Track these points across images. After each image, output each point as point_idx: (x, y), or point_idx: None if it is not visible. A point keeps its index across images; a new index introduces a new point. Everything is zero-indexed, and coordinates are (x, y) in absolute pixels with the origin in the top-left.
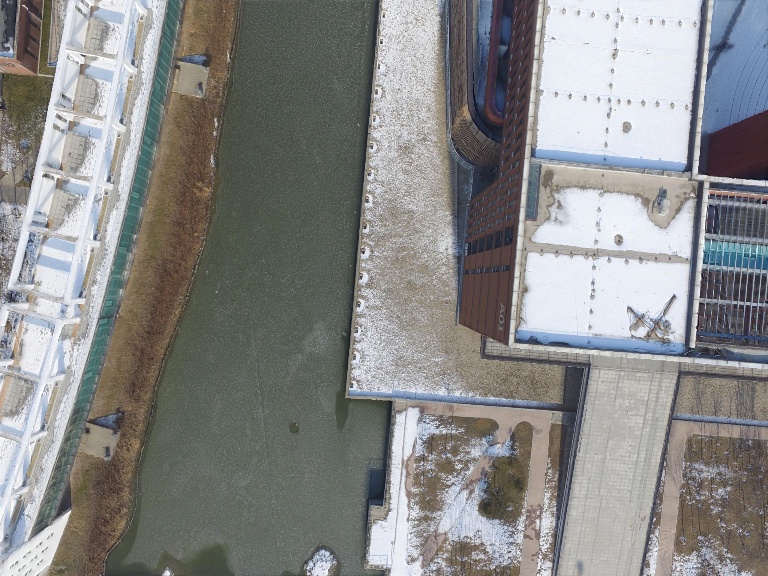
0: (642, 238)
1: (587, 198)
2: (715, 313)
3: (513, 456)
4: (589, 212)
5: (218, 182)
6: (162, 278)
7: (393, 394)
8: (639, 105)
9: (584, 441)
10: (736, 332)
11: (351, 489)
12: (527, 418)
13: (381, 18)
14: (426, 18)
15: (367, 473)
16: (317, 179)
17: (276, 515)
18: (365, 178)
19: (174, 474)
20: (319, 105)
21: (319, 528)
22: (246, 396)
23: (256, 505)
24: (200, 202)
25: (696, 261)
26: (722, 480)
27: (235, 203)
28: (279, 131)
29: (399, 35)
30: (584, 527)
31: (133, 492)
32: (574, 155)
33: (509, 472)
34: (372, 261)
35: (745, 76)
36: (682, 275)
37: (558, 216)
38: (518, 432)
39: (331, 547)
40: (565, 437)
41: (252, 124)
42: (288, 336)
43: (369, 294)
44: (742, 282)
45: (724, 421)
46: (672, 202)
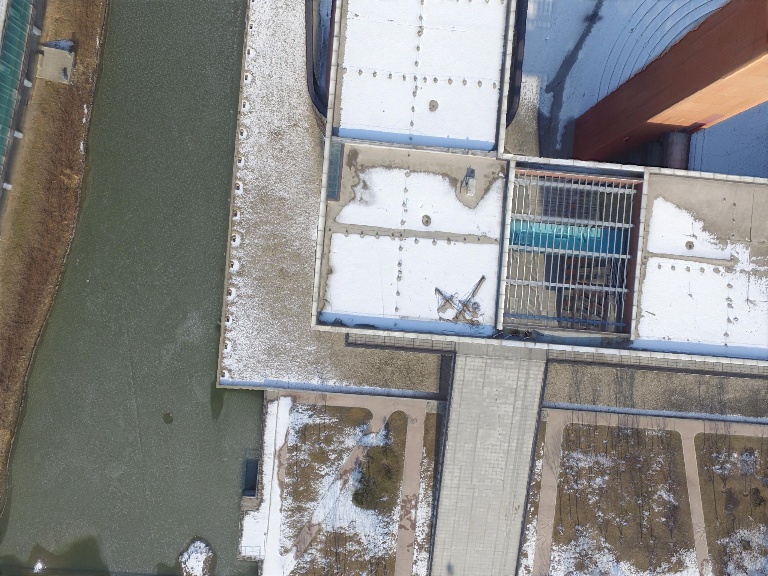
0: (450, 218)
1: (393, 178)
2: (526, 295)
3: (388, 446)
4: (395, 192)
5: (88, 169)
6: (29, 267)
7: (265, 383)
8: (445, 83)
9: (454, 430)
10: (548, 314)
11: (227, 480)
12: (401, 407)
13: (250, 3)
14: (296, 3)
15: (243, 464)
16: (190, 166)
17: (150, 506)
18: (235, 165)
19: (45, 465)
20: (191, 91)
21: (194, 519)
22: (119, 386)
23: (130, 496)
24: (69, 190)
25: (503, 241)
26: (600, 469)
27: (106, 191)
28: (150, 118)
29: (269, 20)
30: (458, 517)
31: (4, 484)
32: (379, 134)
33: (384, 462)
34: (243, 249)
35: (612, 60)
36: (491, 256)
37: (363, 196)
38: (392, 421)
39: (207, 539)
40: (440, 426)
41: (123, 111)
42: (161, 325)
43: (240, 282)
44: (554, 263)
45: (603, 410)
46: (480, 182)
